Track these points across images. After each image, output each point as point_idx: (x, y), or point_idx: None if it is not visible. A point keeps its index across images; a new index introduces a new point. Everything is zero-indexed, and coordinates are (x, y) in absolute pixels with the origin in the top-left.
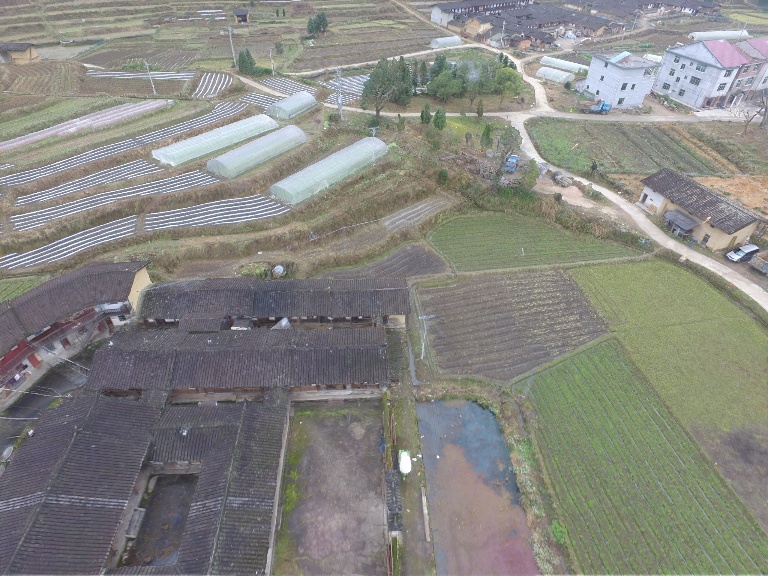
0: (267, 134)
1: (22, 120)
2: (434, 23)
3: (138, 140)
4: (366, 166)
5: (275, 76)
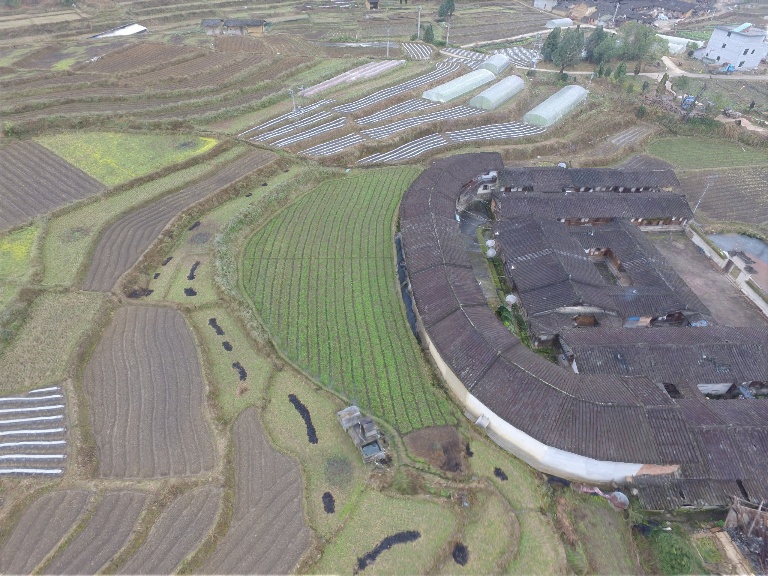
0: (492, 83)
1: (310, 72)
2: (538, 8)
3: (403, 86)
4: (578, 105)
5: (448, 47)
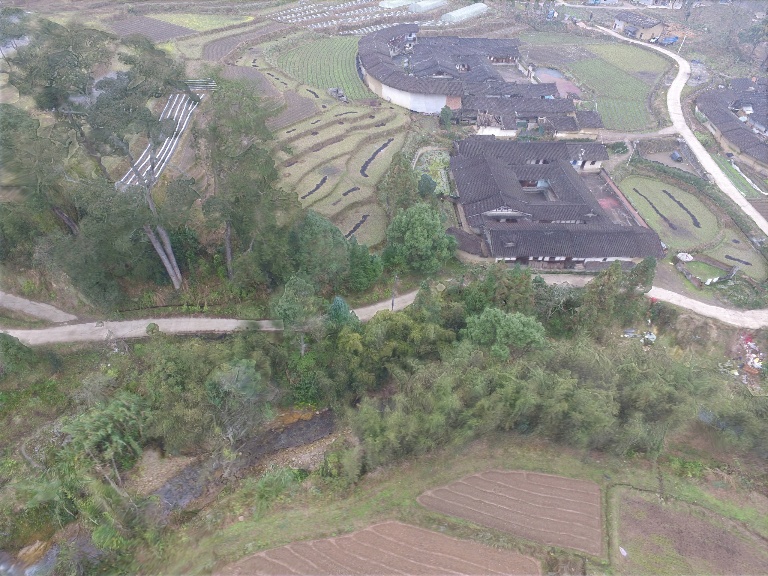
0: None
1: None
2: None
3: None
4: (479, 14)
5: None
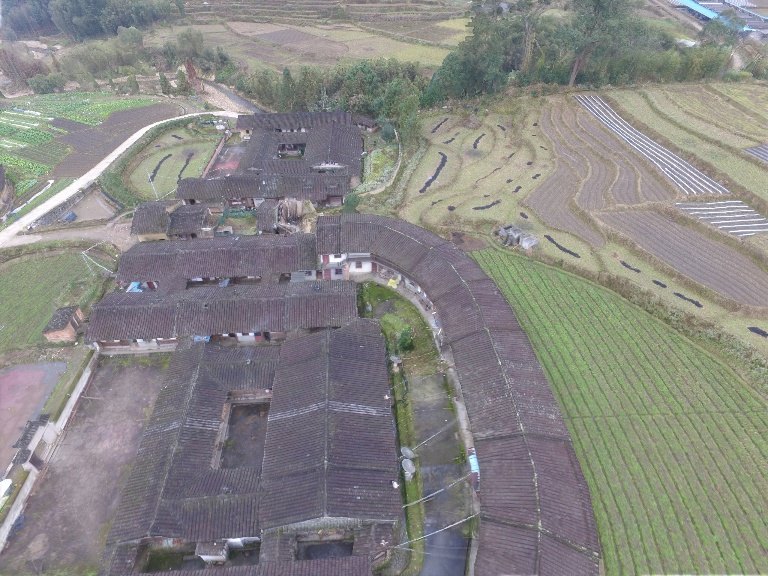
0: None
1: None
2: None
3: None
4: None
5: None
